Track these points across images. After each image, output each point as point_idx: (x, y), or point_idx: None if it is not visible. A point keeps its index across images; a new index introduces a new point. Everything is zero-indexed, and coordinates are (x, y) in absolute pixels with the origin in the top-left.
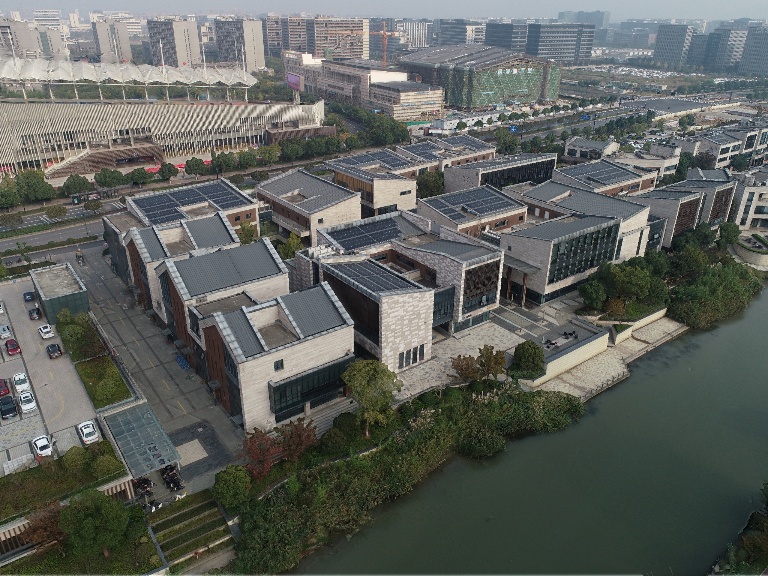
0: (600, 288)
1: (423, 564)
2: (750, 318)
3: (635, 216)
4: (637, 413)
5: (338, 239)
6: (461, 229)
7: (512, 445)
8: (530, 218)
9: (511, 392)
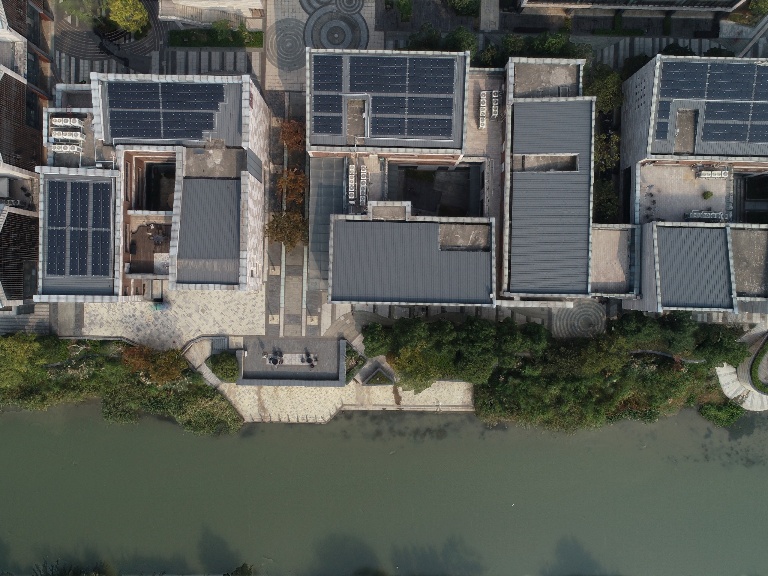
0: (379, 350)
1: (4, 465)
2: (560, 443)
3: (549, 296)
4: (277, 461)
5: (114, 105)
6: (316, 152)
7: (147, 420)
8: (488, 146)
9: (179, 387)
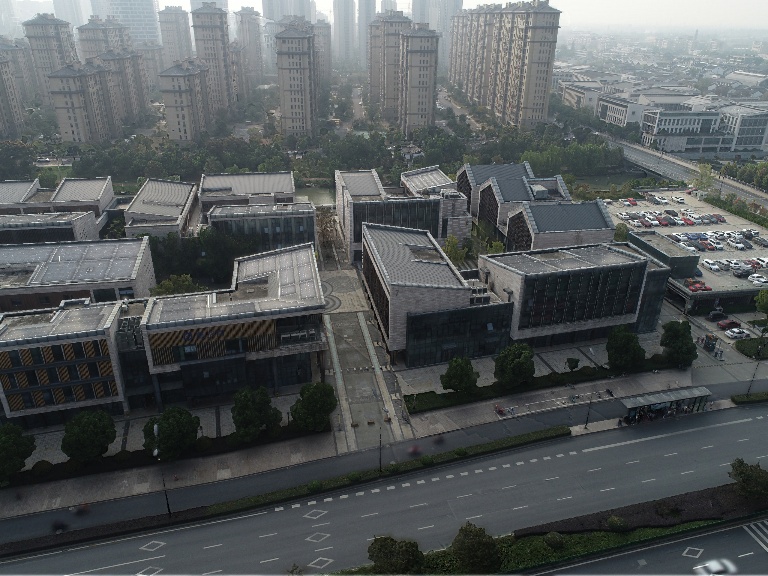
0: None
1: None
2: None
3: None
4: None
5: None
6: None
7: None
8: None
9: None
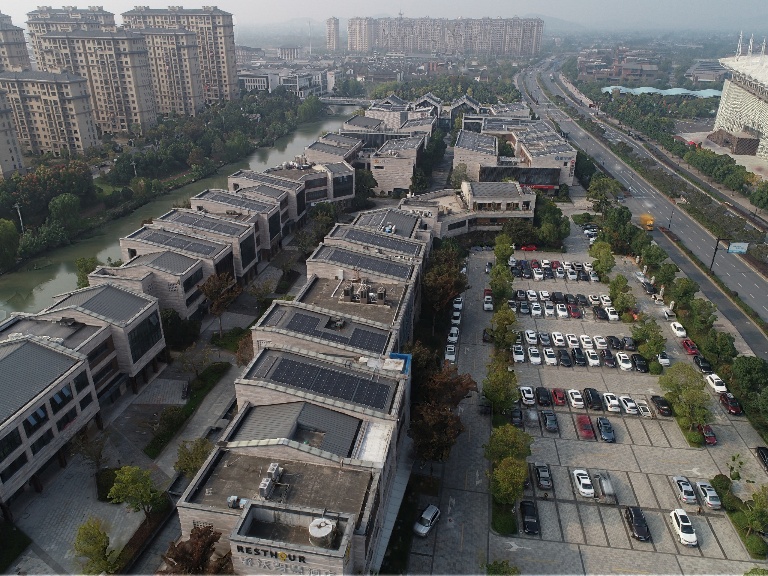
0: None
1: None
2: None
3: None
4: None
5: None
6: None
7: None
8: None
9: None
